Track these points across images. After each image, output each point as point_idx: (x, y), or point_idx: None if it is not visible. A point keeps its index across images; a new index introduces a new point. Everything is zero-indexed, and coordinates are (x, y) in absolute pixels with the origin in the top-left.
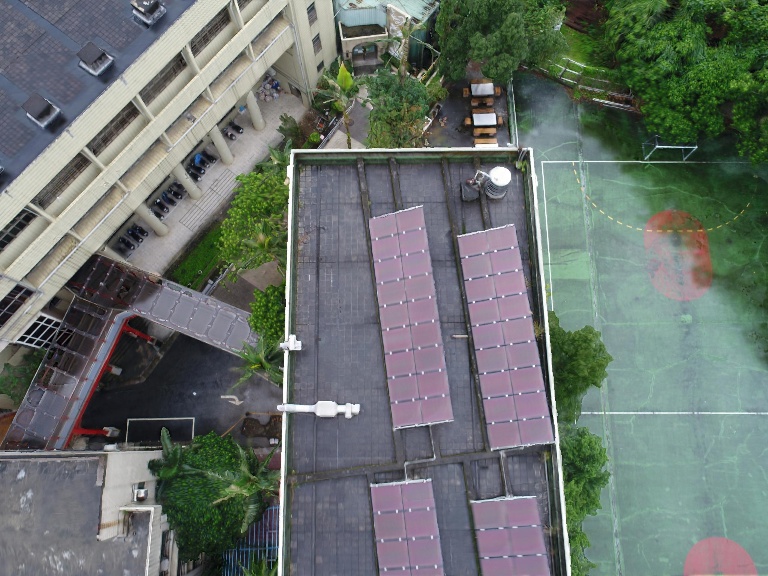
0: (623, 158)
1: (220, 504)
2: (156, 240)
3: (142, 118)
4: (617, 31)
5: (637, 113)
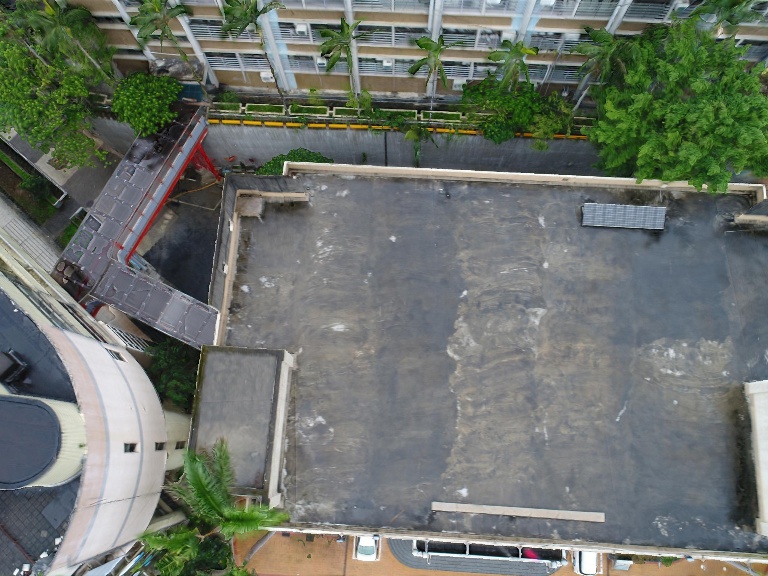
0: None
1: None
2: None
3: None
4: None
5: None
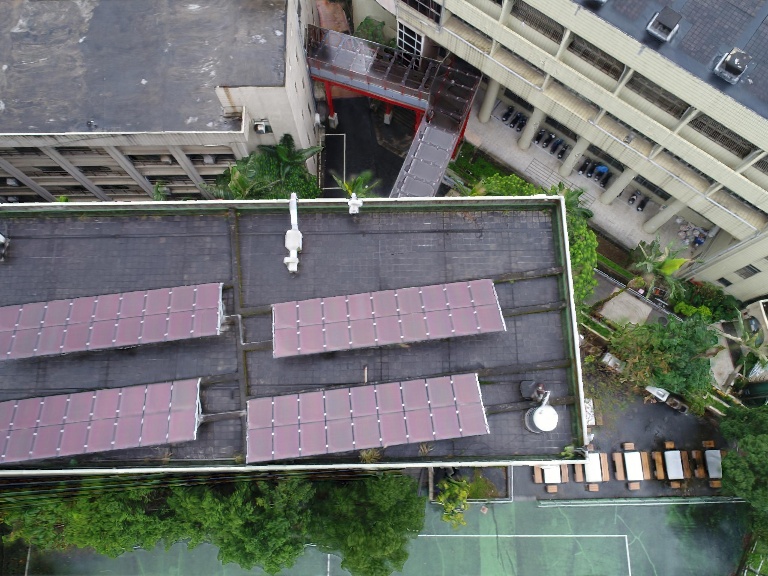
0: None
1: None
2: (514, 139)
3: None
4: None
5: None
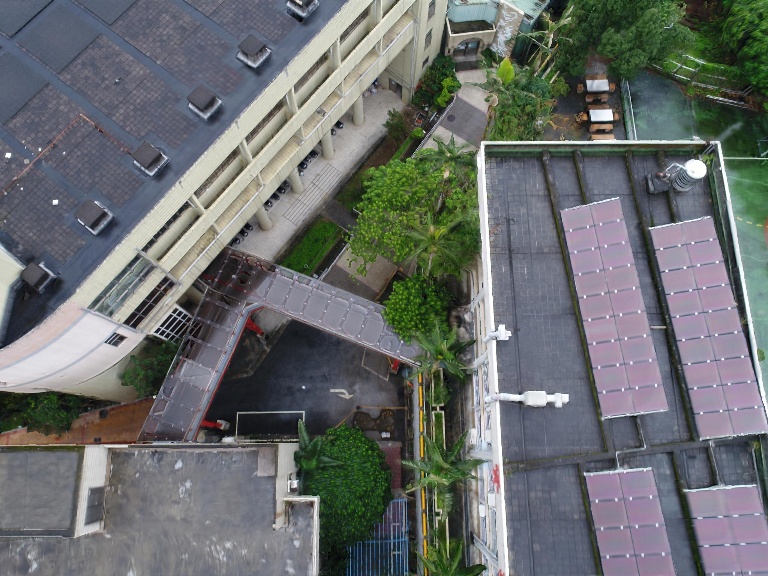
0: (739, 155)
1: (361, 496)
2: (260, 234)
3: (284, 111)
4: (741, 28)
5: (751, 110)
